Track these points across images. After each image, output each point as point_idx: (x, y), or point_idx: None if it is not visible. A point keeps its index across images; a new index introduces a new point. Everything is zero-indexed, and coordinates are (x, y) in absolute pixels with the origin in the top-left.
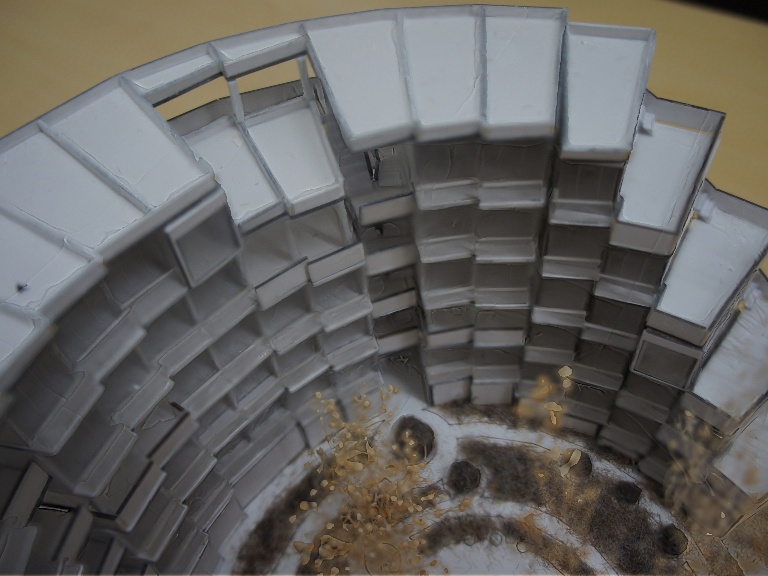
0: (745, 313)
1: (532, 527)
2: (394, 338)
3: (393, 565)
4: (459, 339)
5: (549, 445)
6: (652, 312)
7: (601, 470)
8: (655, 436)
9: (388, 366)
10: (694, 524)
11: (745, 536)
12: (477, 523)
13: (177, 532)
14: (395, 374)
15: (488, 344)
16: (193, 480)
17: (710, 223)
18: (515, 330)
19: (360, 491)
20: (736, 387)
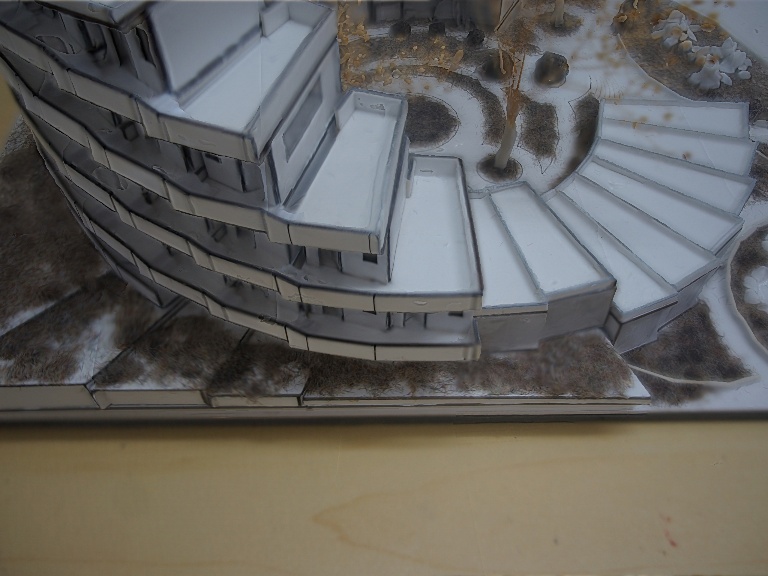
0: None
1: None
2: None
3: None
4: None
5: (377, 32)
6: None
7: (415, 31)
8: None
9: None
10: (481, 28)
11: None
12: None
13: None
14: None
15: None
16: None
17: None
18: None
19: None
20: None
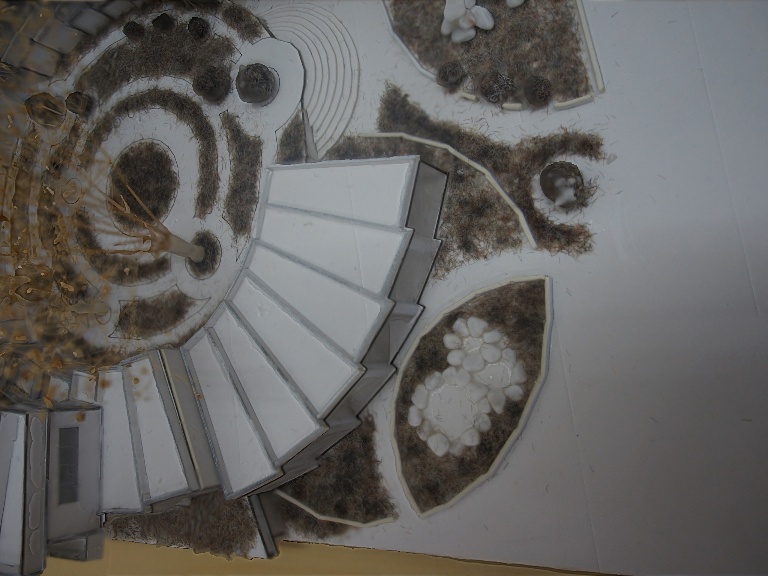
0: None
1: (130, 97)
2: None
3: None
4: None
5: (118, 37)
6: None
7: (150, 23)
8: None
9: (18, 78)
10: (205, 5)
11: None
12: (102, 124)
13: None
14: (23, 79)
15: None
16: None
17: None
18: None
19: None
20: None
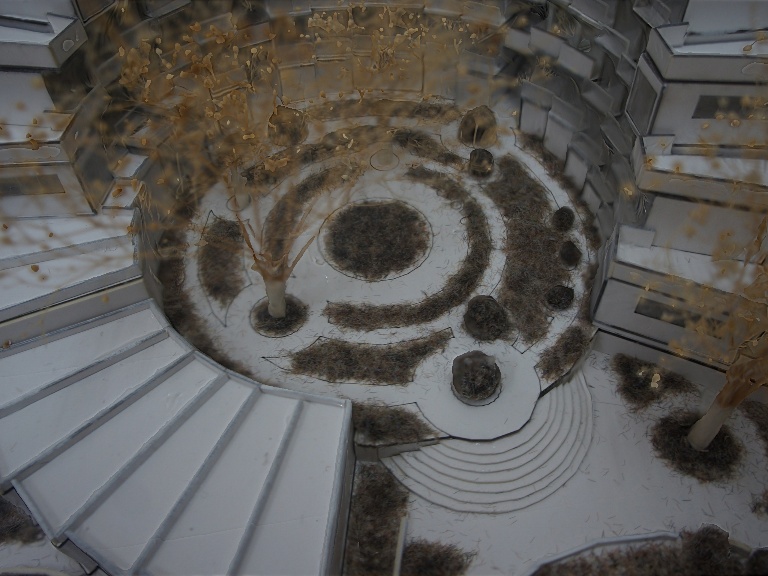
0: None
1: (485, 219)
2: (520, 35)
3: None
4: (553, 51)
5: (560, 200)
6: (651, 29)
7: (574, 237)
8: (614, 203)
9: None
10: None
11: (626, 365)
12: (457, 189)
13: (295, 19)
14: None
15: (567, 65)
16: (327, 3)
17: None
18: (589, 58)
19: (383, 43)
20: None
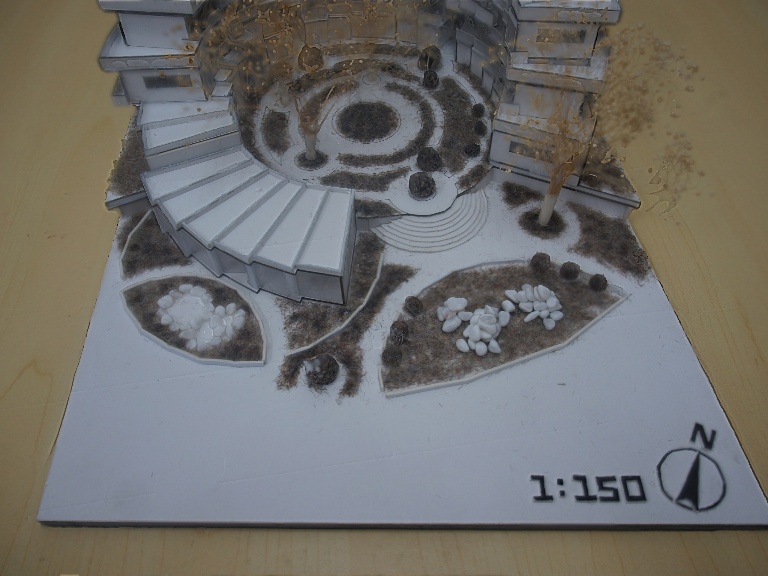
0: (587, 67)
1: (432, 111)
2: (455, 1)
3: (345, 1)
4: (472, 9)
5: (478, 101)
6: None
7: (484, 121)
8: None
9: None
10: None
11: (509, 187)
12: (415, 95)
13: None
14: None
15: (480, 18)
16: None
17: (598, 3)
18: (491, 13)
19: (370, 4)
20: (537, 75)
